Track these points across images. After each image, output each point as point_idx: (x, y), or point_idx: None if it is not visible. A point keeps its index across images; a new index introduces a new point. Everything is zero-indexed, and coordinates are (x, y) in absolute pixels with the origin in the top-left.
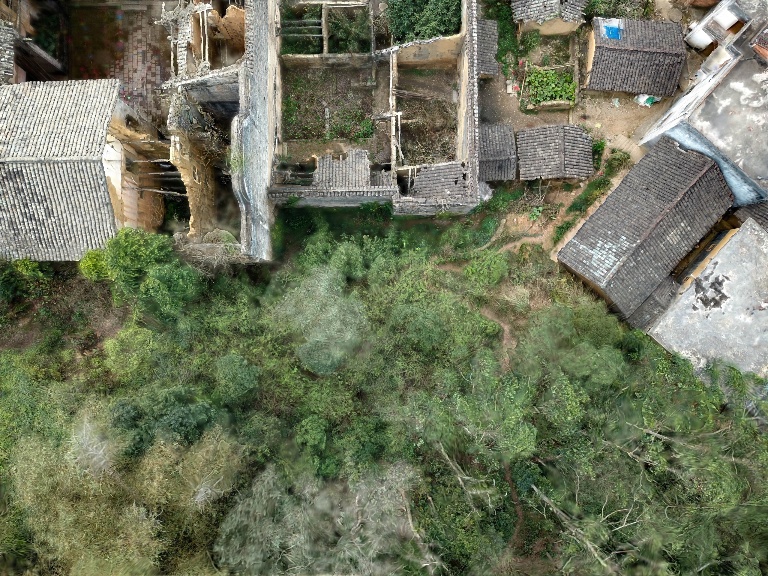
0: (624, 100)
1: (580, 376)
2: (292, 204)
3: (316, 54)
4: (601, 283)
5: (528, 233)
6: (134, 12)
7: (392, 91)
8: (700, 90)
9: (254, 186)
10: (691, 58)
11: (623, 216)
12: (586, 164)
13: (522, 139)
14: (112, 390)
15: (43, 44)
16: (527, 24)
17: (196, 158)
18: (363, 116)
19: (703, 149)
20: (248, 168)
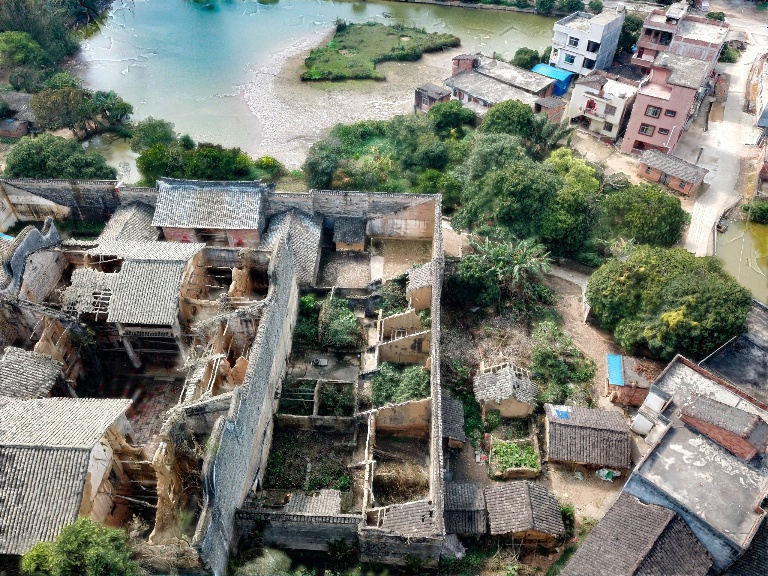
0: (586, 474)
1: None
2: (258, 538)
3: (306, 415)
4: None
5: None
6: (163, 382)
7: (370, 450)
8: None
9: (223, 488)
10: (640, 442)
11: (598, 566)
12: (556, 522)
13: (490, 495)
14: None
15: (79, 396)
16: (487, 403)
17: (177, 476)
18: (342, 472)
19: (662, 502)
20: (221, 465)
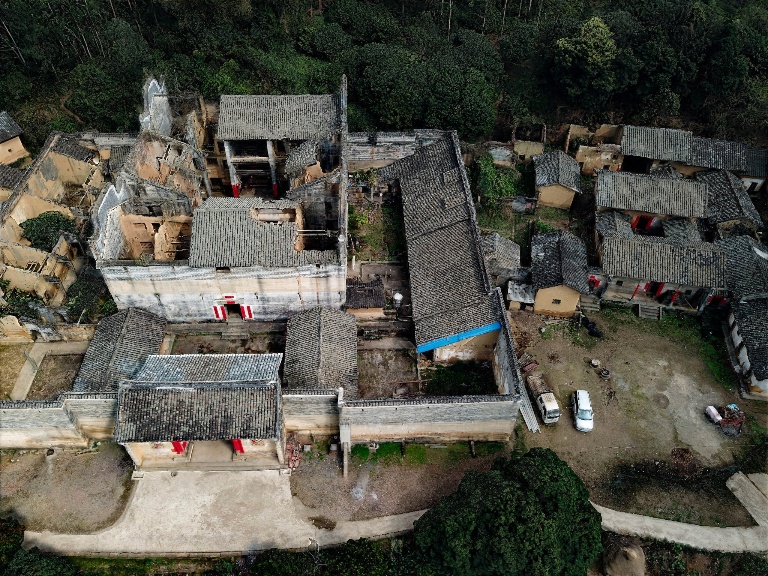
0: None
1: (24, 2)
2: None
3: None
4: (6, 113)
5: None
6: None
7: None
8: None
9: None
10: None
11: None
12: None
13: None
14: (249, 75)
15: None
16: None
17: None
18: None
19: None
20: None
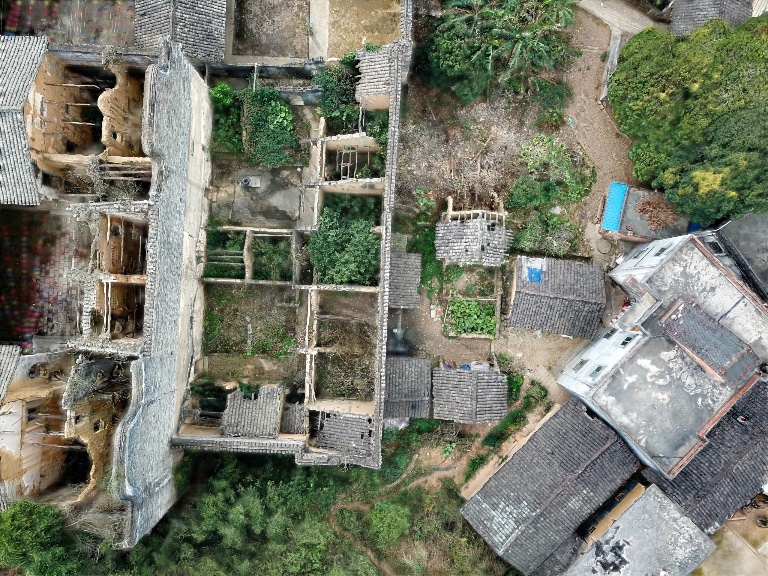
0: None
1: None
2: None
3: (238, 279)
4: (498, 550)
5: (440, 467)
6: (63, 216)
7: (314, 316)
8: (612, 353)
9: (146, 467)
10: (615, 294)
11: (526, 479)
12: (500, 407)
13: (438, 378)
14: None
15: None
16: (449, 263)
17: (101, 408)
18: (285, 334)
19: (608, 421)
20: (136, 462)
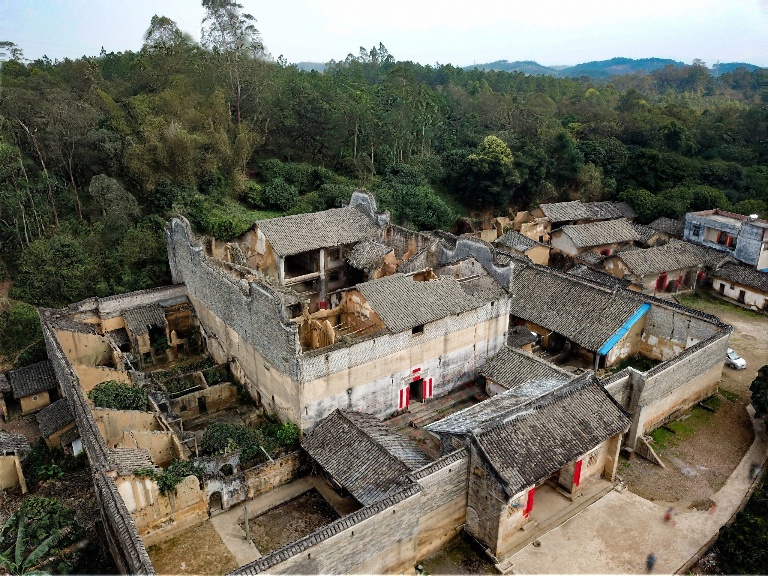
0: None
1: None
2: None
3: None
4: None
5: None
6: None
7: None
8: None
9: None
10: None
11: None
12: None
13: (5, 386)
14: None
15: None
16: None
17: None
18: None
19: None
20: None
